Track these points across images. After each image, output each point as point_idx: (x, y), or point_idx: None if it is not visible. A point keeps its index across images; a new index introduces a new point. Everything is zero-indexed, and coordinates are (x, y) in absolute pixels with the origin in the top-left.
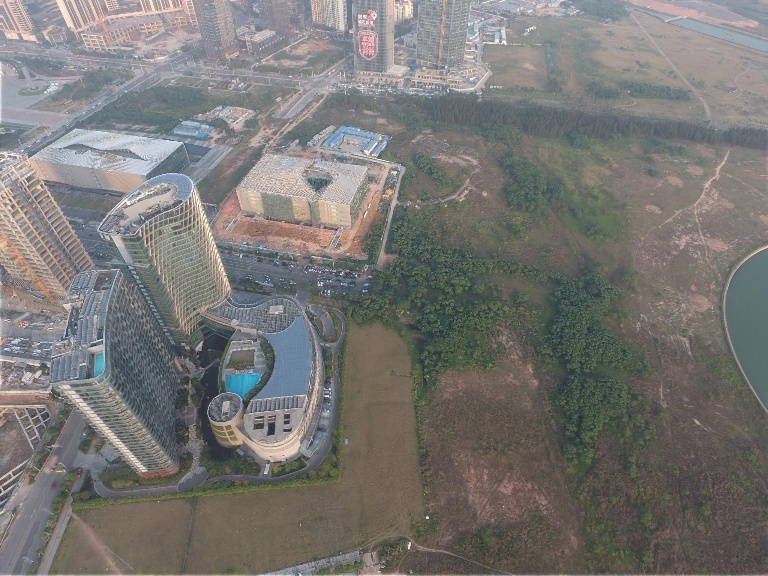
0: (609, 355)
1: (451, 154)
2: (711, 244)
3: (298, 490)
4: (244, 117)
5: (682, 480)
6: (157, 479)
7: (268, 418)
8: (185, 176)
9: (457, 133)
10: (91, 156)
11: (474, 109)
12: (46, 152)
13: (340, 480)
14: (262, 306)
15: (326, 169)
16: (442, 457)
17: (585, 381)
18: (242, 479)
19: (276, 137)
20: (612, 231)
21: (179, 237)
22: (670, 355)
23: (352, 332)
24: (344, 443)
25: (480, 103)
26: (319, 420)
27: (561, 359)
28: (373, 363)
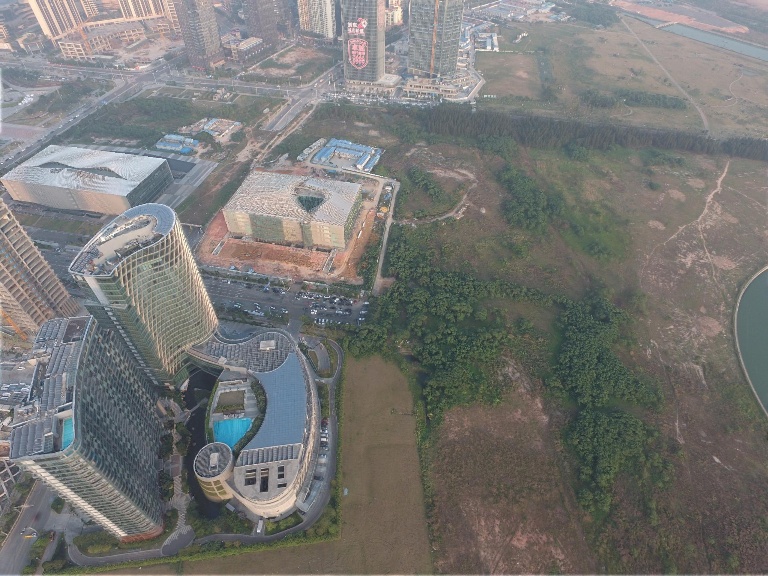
0: (621, 387)
1: (447, 168)
2: (718, 262)
3: (294, 550)
4: (230, 130)
5: (705, 527)
6: (138, 542)
7: (260, 471)
8: (166, 206)
9: (452, 146)
10: (67, 175)
11: (469, 120)
12: (19, 171)
13: (340, 537)
14: (252, 341)
15: (318, 187)
16: (450, 507)
17: (598, 417)
18: (233, 539)
19: (264, 151)
20: (616, 249)
21: (160, 273)
22: (684, 385)
23: (349, 366)
24: (343, 493)
25: (475, 114)
26: (316, 467)
27: (571, 392)
28: (372, 400)
